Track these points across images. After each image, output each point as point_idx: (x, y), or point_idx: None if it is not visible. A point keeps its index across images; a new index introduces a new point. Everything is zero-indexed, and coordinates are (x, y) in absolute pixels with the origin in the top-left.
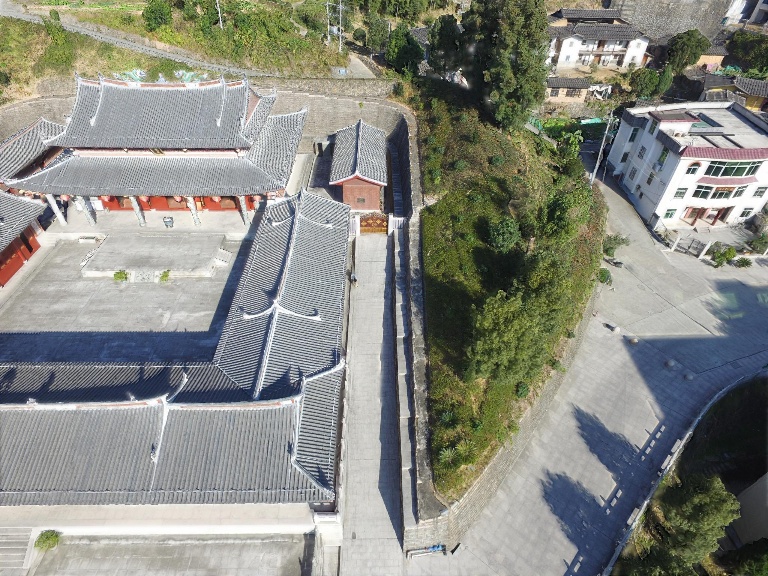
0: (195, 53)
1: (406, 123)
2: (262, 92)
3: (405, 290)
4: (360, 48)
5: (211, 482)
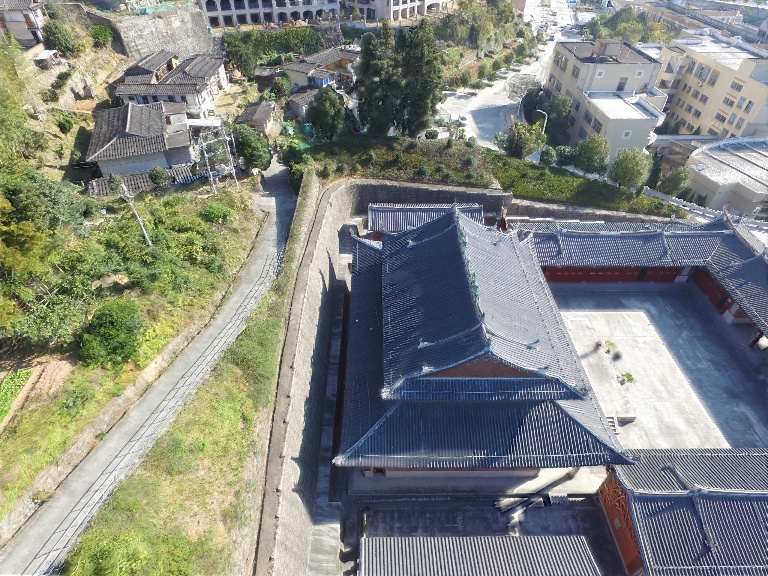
0: (192, 324)
1: (372, 185)
2: (314, 264)
3: (567, 218)
4: (160, 191)
5: (767, 250)
